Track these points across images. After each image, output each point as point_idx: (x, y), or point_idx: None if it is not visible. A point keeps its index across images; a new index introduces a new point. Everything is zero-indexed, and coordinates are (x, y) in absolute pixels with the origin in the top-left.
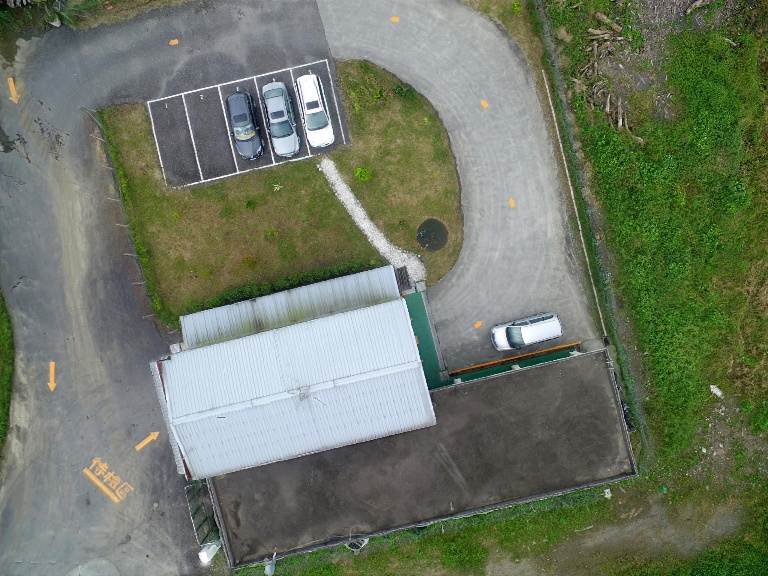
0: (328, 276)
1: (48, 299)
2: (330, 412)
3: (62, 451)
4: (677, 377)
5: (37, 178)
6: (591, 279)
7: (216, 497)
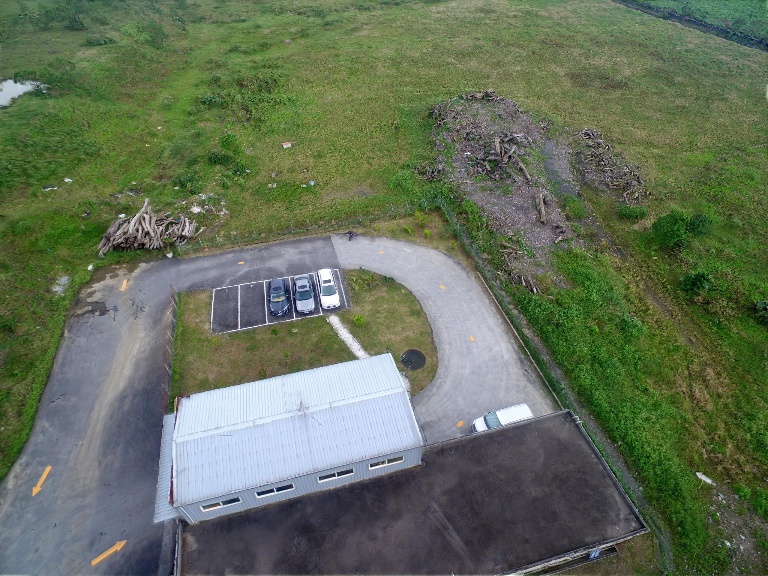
0: None
1: (77, 411)
2: (324, 432)
3: (4, 568)
4: (656, 459)
5: (115, 330)
6: (549, 388)
7: (180, 573)
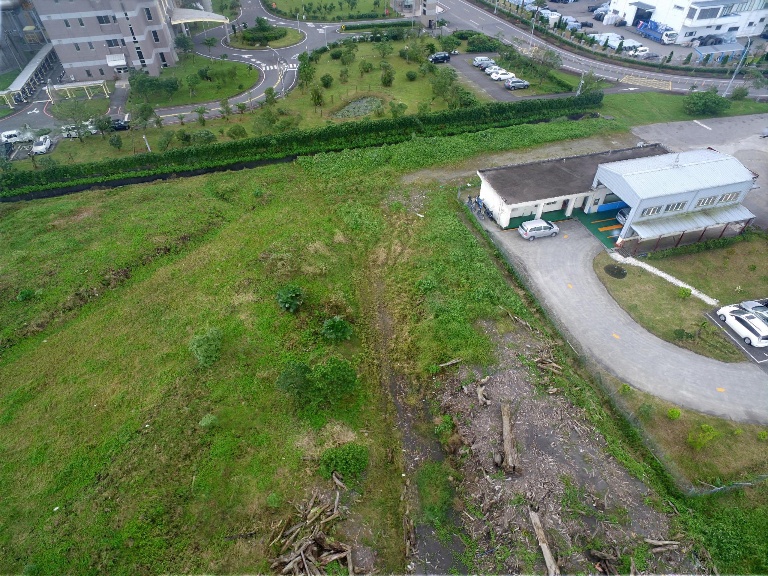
0: None
1: None
2: None
3: None
4: None
5: None
6: None
7: None
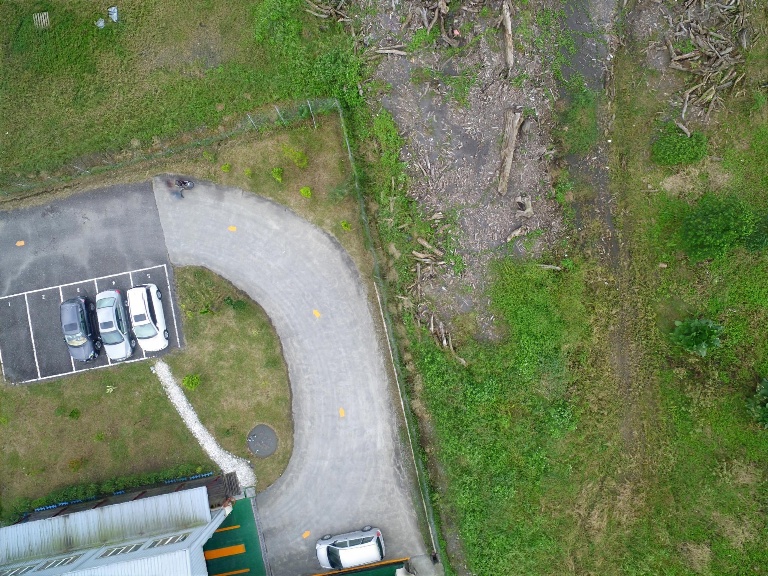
0: (154, 483)
1: None
2: None
3: None
4: None
5: None
6: (421, 492)
7: None
